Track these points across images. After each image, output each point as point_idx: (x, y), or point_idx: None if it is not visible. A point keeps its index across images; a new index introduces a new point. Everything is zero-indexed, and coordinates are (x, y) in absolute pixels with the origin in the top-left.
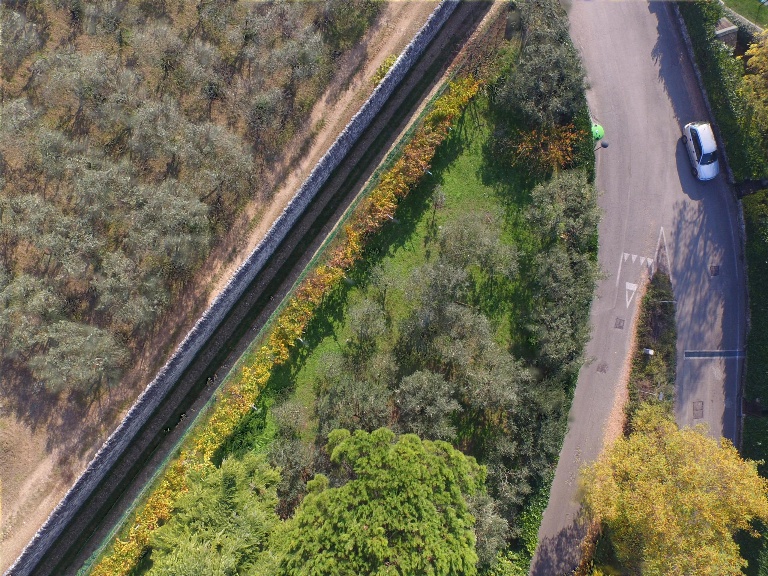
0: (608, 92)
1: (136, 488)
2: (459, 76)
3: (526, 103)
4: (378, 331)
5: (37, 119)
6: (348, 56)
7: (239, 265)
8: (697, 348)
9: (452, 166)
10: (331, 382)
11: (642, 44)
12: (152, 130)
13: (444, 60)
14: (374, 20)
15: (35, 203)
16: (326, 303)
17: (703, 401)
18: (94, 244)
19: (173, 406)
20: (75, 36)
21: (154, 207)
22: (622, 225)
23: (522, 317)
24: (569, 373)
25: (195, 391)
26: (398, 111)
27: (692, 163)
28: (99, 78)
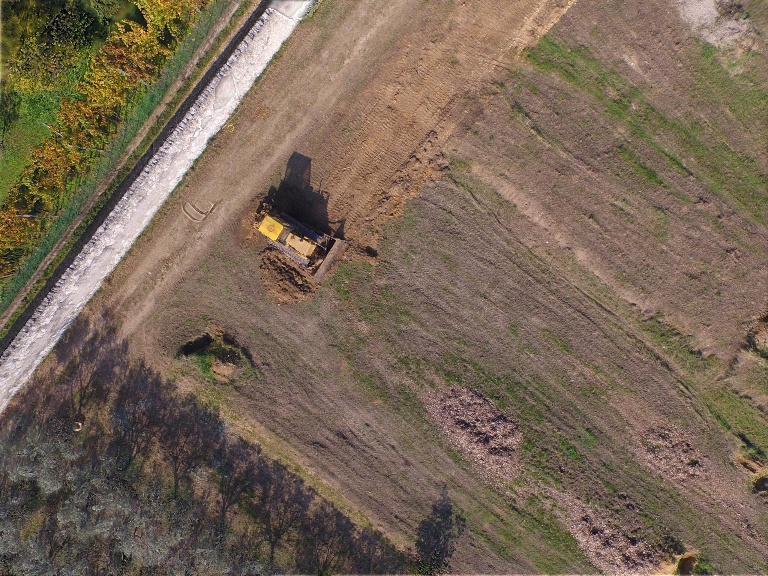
0: None
1: None
2: None
3: None
4: None
5: None
6: None
7: None
8: None
9: None
10: None
11: None
12: None
13: None
14: None
15: None
16: None
17: None
18: None
19: None
20: None
21: None
22: None
23: None
24: None
25: None
26: None
27: None
28: None
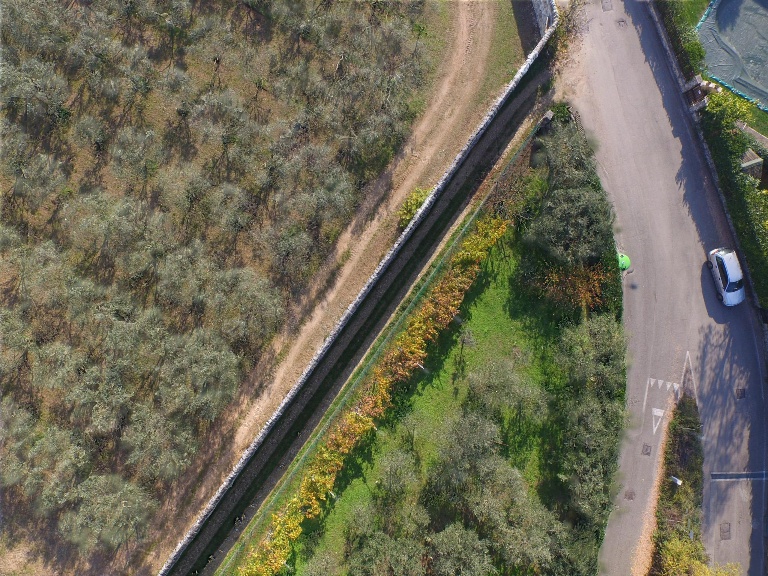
0: (633, 217)
1: None
2: (485, 207)
3: (555, 246)
4: (407, 472)
5: (62, 253)
6: (373, 186)
7: (266, 402)
8: (724, 470)
9: (479, 300)
10: (361, 525)
11: (666, 168)
12: (178, 263)
13: (469, 188)
14: (399, 148)
15: (64, 354)
16: (355, 444)
17: (730, 523)
18: (124, 399)
19: (201, 547)
20: (100, 167)
21: (180, 342)
22: (648, 350)
23: (551, 452)
24: (600, 519)
25: (223, 532)
26: (424, 241)
27: (717, 288)
28: (128, 228)
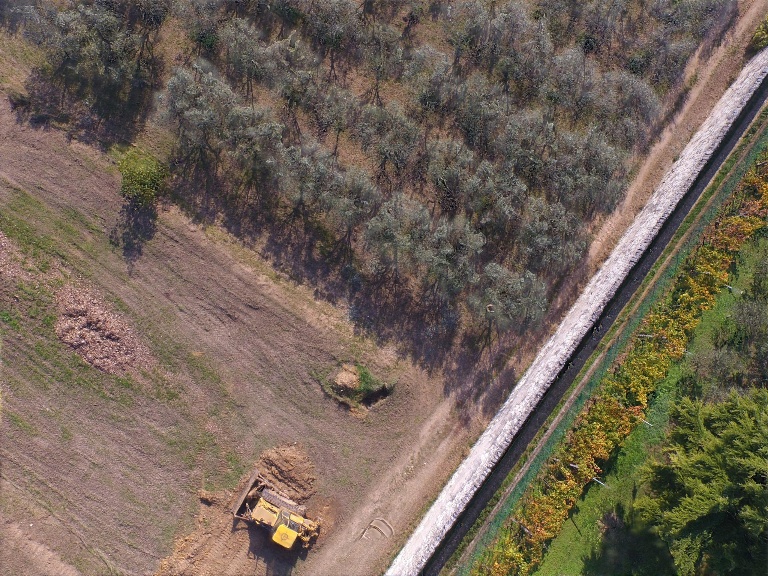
0: None
1: (528, 433)
2: None
3: None
4: None
5: (415, 69)
6: (720, 12)
7: None
8: None
9: None
10: (728, 333)
11: None
12: (528, 82)
13: None
14: None
15: (459, 147)
16: None
17: None
18: (526, 188)
19: None
20: None
21: None
22: None
23: None
24: None
25: (582, 340)
26: None
27: None
28: (524, 24)
